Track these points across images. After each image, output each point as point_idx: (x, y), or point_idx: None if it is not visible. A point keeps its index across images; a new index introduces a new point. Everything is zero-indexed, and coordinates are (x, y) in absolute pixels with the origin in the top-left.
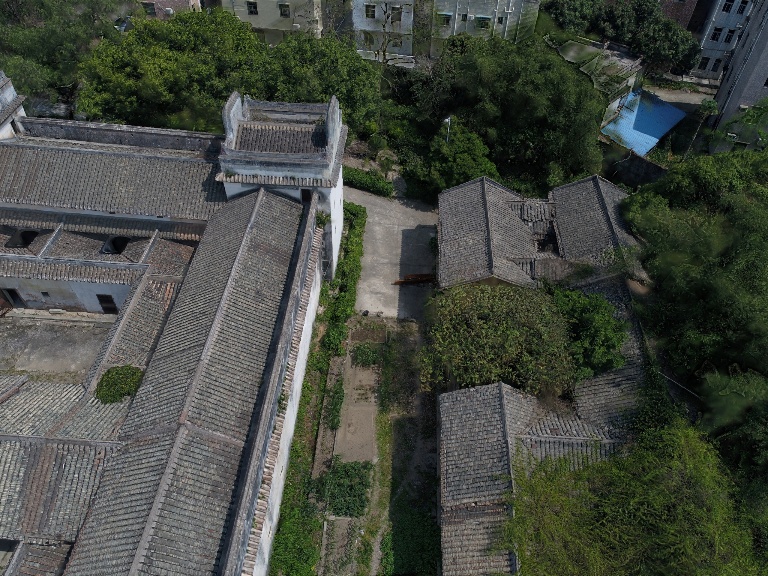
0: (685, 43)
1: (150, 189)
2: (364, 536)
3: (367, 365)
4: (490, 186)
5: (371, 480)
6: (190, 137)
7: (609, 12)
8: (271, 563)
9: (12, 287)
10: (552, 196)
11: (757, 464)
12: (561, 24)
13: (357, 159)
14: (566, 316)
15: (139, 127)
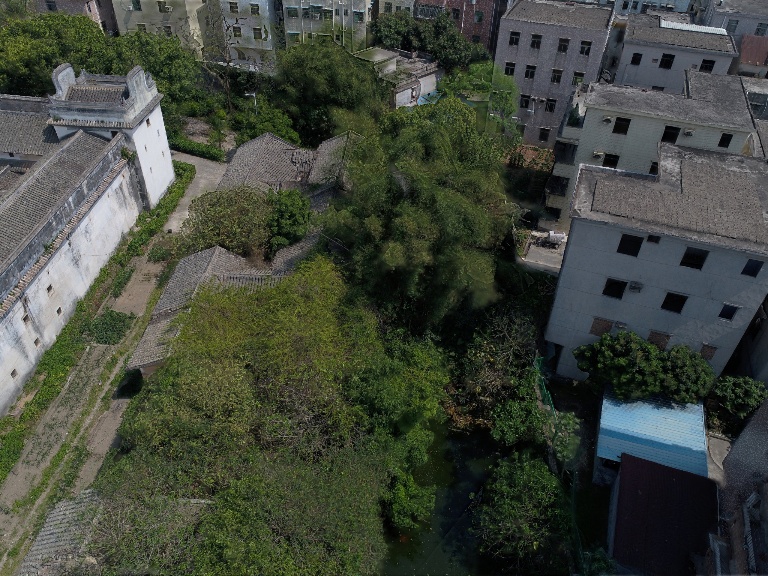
0: (468, 50)
1: (3, 134)
2: (114, 355)
3: (158, 261)
4: (272, 139)
5: (132, 325)
6: (44, 102)
7: (416, 29)
8: (38, 365)
9: None
10: (320, 147)
11: (359, 279)
12: (380, 38)
13: (205, 137)
14: (274, 205)
15: (5, 95)
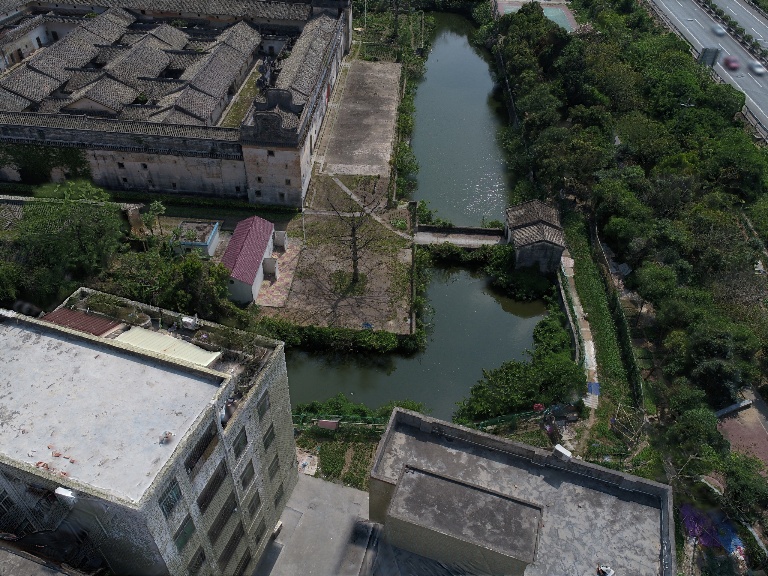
0: None
1: (9, 0)
2: None
3: None
4: None
5: None
6: None
7: None
8: None
9: (19, 47)
10: None
11: None
12: None
13: None
14: None
15: None
